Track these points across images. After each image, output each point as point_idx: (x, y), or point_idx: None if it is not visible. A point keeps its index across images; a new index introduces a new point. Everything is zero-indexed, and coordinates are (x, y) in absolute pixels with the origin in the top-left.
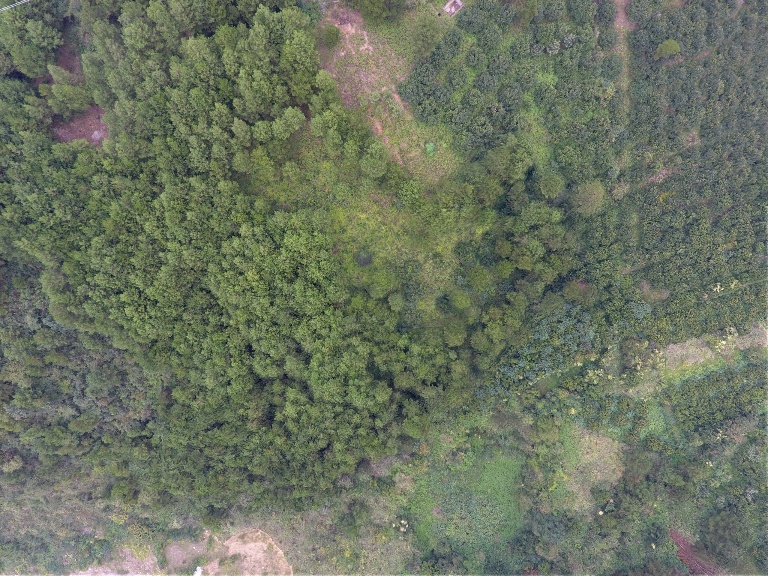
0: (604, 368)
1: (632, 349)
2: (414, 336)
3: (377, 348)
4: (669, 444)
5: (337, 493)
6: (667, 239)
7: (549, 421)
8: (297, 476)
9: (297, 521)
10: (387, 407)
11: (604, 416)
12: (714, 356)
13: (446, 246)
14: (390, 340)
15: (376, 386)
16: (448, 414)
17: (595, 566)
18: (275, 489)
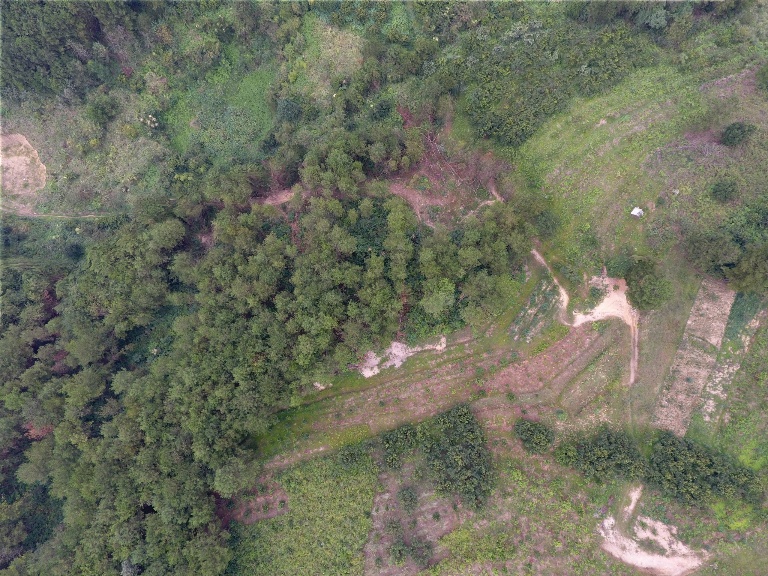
0: None
1: None
2: None
3: None
4: (406, 34)
5: (71, 61)
6: None
7: (286, 5)
8: (17, 19)
9: (49, 117)
10: None
11: (345, 8)
12: None
13: None
14: None
15: None
16: None
17: (323, 139)
18: (2, 43)
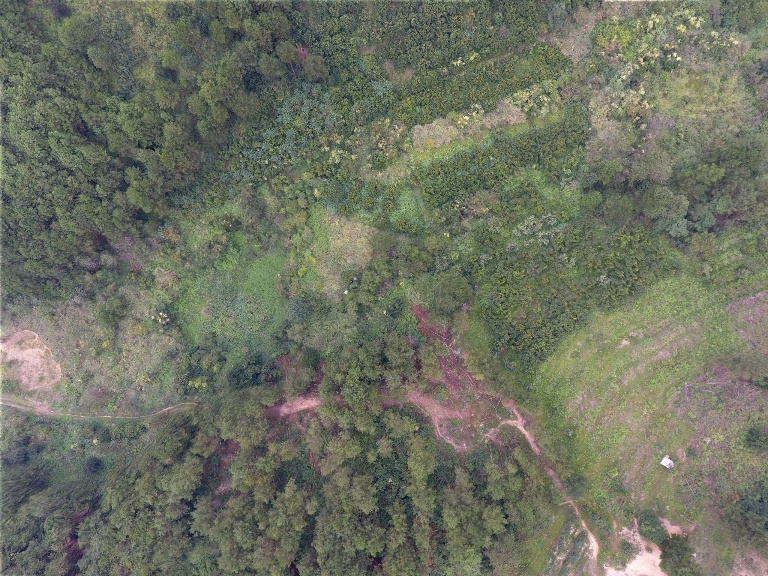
0: (351, 151)
1: (375, 128)
2: (129, 100)
3: (84, 106)
4: (416, 224)
5: (80, 274)
6: (400, 10)
7: (293, 202)
8: (24, 246)
9: (61, 317)
10: (105, 172)
11: (352, 199)
12: (463, 136)
13: (156, 8)
14: (98, 99)
15: (86, 145)
16: (195, 200)
17: (336, 341)
18: (11, 265)
